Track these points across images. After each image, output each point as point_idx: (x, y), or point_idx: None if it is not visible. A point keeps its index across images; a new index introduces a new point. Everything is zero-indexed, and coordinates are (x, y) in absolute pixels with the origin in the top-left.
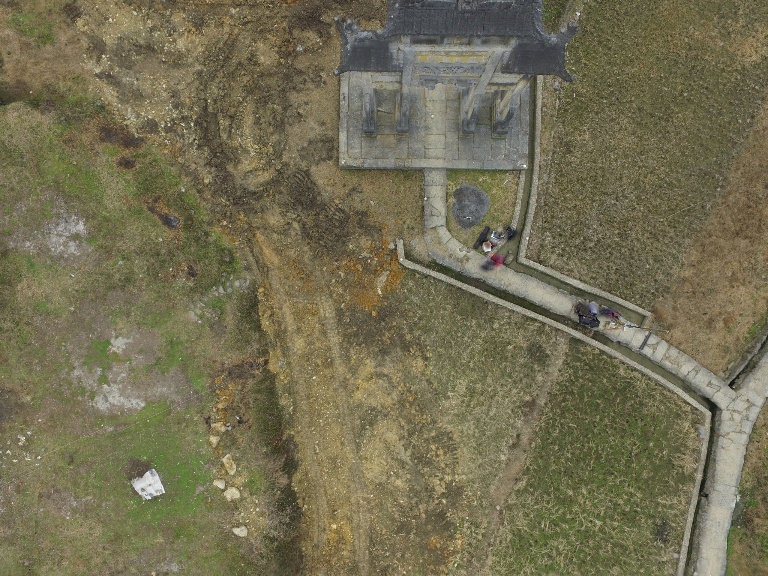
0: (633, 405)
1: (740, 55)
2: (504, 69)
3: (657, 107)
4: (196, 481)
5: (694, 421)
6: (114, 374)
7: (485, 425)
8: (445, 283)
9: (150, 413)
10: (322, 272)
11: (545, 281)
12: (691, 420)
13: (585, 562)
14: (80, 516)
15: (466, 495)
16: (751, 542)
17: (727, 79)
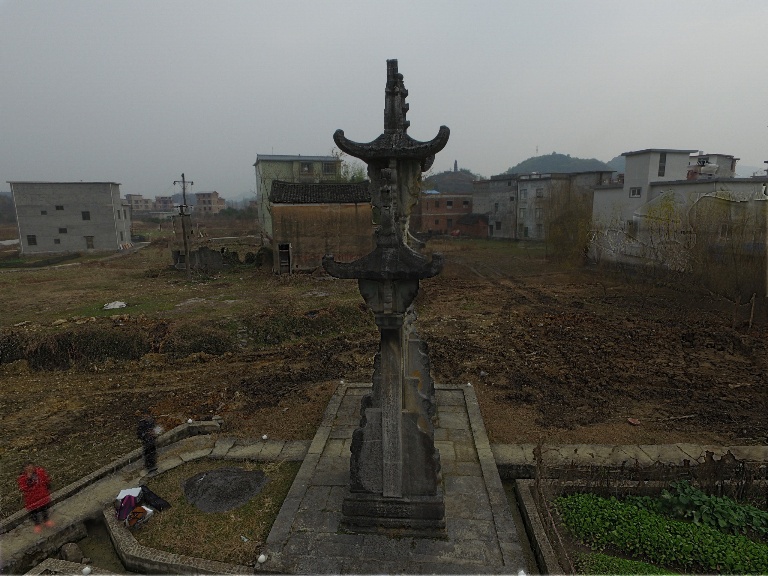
0: None
1: None
2: None
3: None
4: None
5: None
6: None
7: None
8: None
9: None
10: None
11: None
12: None
13: None
14: None
15: None
16: None
17: None
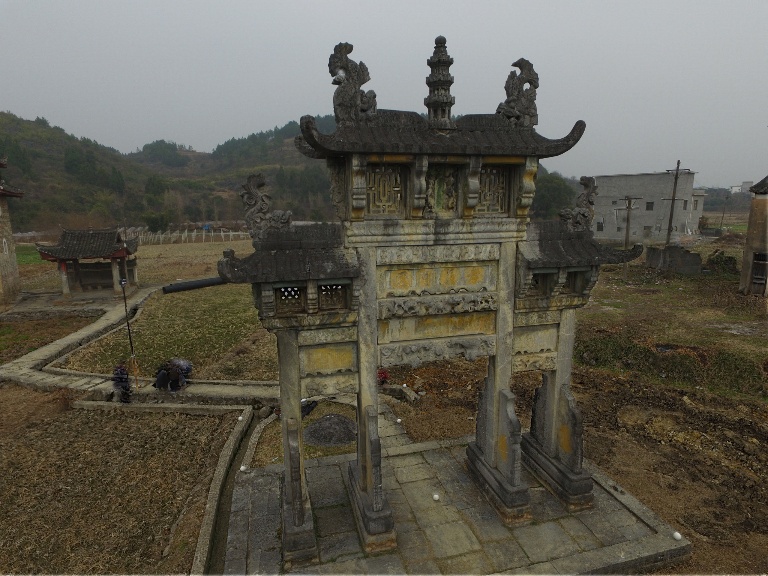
0: None
1: None
2: None
3: None
4: None
5: None
6: None
7: None
8: None
9: None
10: None
11: None
12: None
13: None
14: None
15: None
16: None
17: None
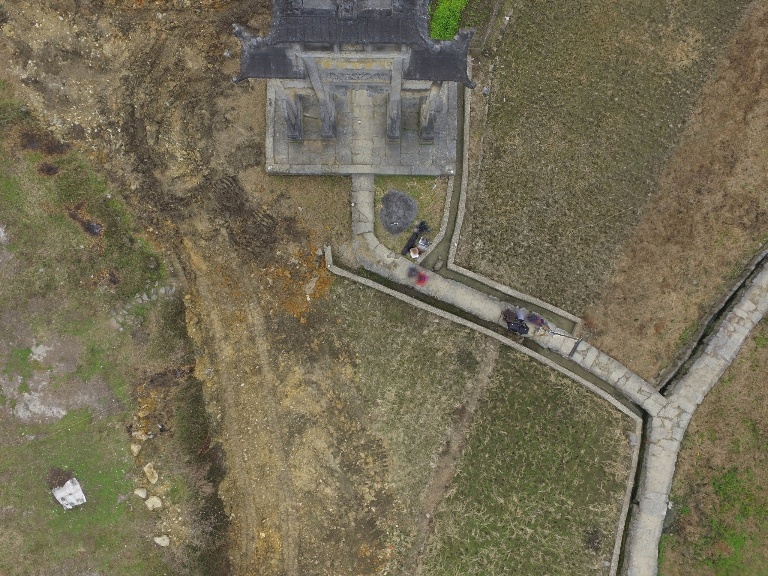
0: (564, 412)
1: (671, 59)
2: (405, 76)
3: (588, 112)
4: (118, 490)
5: (625, 428)
6: (35, 382)
7: (415, 432)
8: (374, 289)
9: (71, 421)
10: (250, 279)
11: (475, 287)
12: (622, 427)
13: (516, 570)
14: (1, 526)
15: (396, 503)
16: (684, 550)
17: (658, 84)
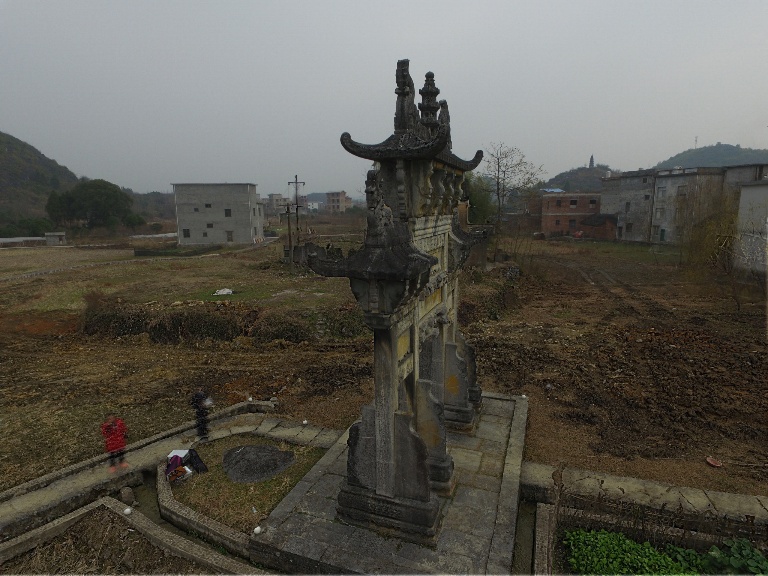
0: None
1: None
2: None
3: None
4: None
5: None
6: None
7: None
8: None
9: None
10: None
11: None
12: None
13: None
14: None
15: None
16: None
17: None
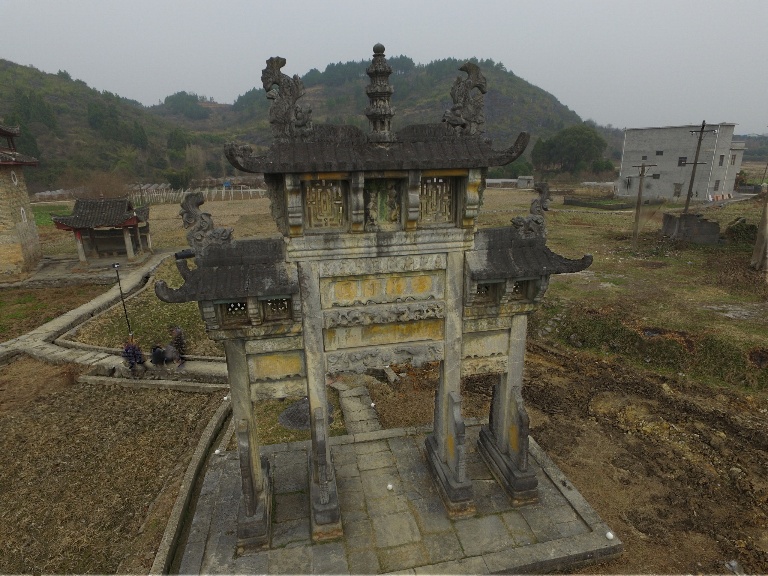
0: None
1: None
2: None
3: None
4: None
5: None
6: None
7: None
8: None
9: None
10: None
11: None
12: None
13: None
14: None
15: None
16: None
17: None
